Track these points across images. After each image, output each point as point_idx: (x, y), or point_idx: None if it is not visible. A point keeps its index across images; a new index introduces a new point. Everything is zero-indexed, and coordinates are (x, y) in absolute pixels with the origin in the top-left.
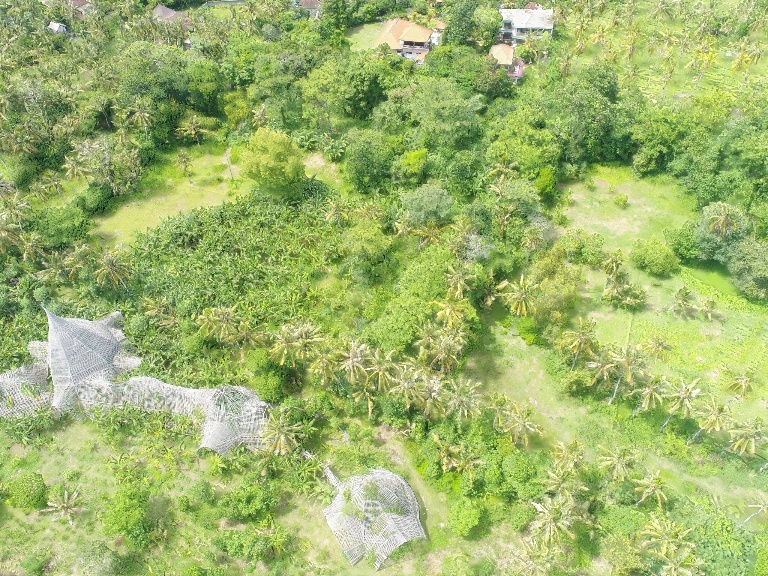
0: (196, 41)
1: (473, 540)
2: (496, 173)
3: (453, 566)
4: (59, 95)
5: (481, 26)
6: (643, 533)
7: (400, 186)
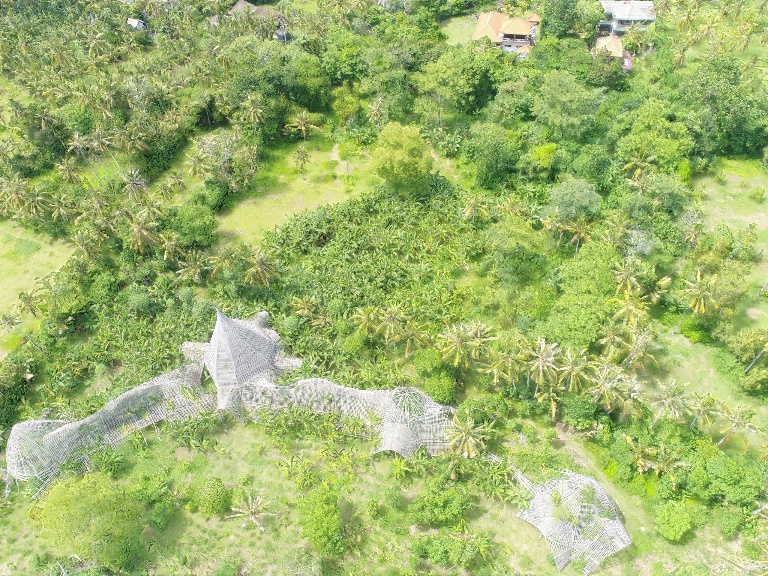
0: (299, 35)
1: (679, 544)
2: (631, 167)
3: (681, 572)
4: (161, 91)
5: (584, 18)
6: None
7: (527, 181)
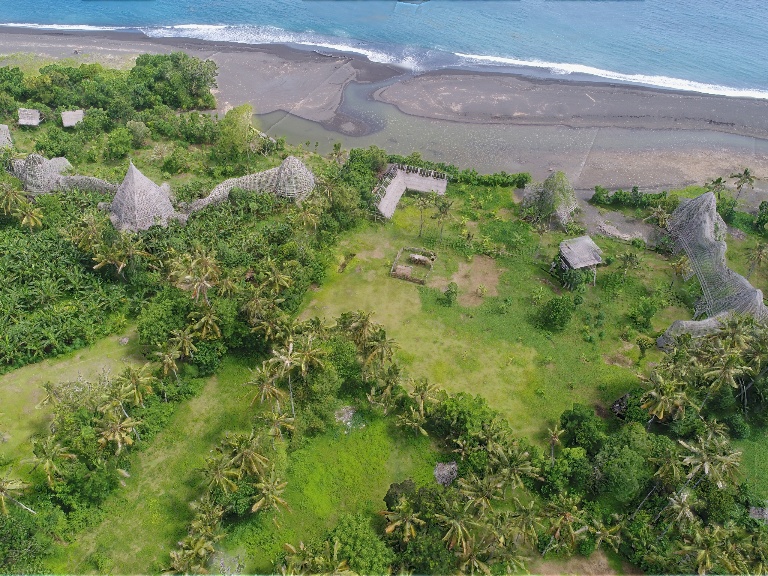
0: None
1: None
2: None
3: None
4: None
5: None
6: None
7: None
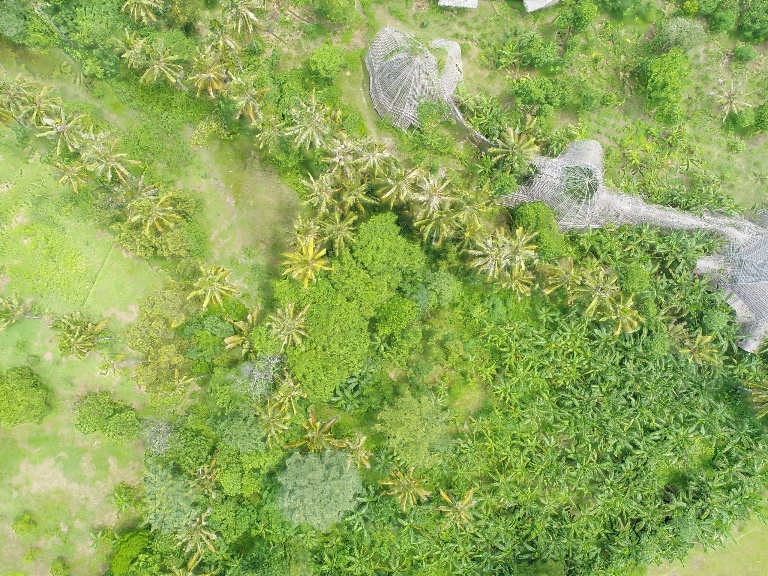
0: None
1: None
2: (199, 575)
3: (342, 2)
4: None
5: None
6: (159, 6)
7: None
